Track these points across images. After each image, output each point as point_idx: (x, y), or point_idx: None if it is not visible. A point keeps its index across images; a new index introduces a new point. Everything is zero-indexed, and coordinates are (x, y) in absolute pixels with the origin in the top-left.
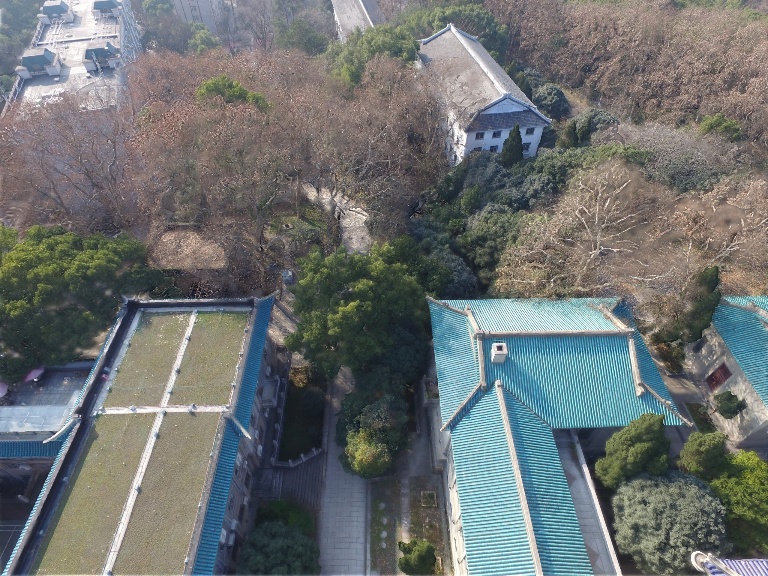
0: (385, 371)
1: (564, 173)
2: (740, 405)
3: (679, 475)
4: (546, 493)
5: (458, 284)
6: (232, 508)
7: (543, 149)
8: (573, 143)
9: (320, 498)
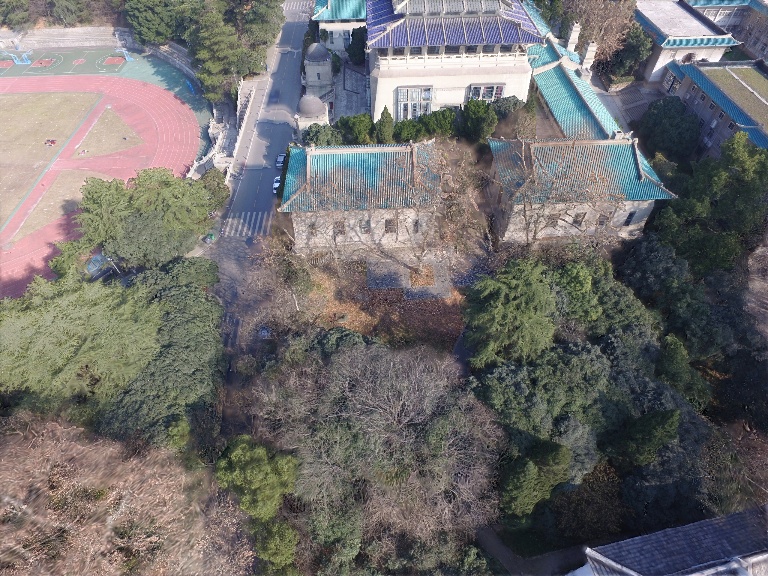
0: (673, 190)
1: None
2: None
3: (505, 117)
4: None
5: None
6: (716, 147)
7: (590, 459)
8: None
9: None
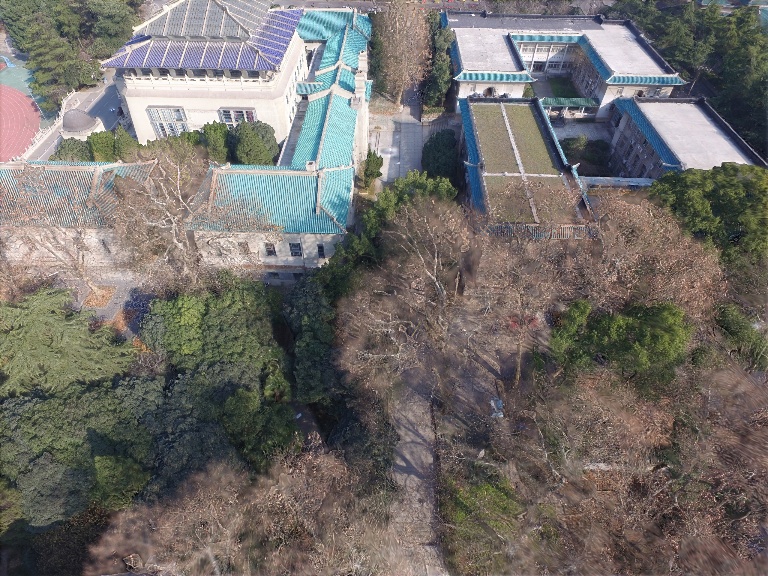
0: None
1: None
2: None
3: None
4: None
5: None
6: None
7: (48, 501)
8: None
9: None
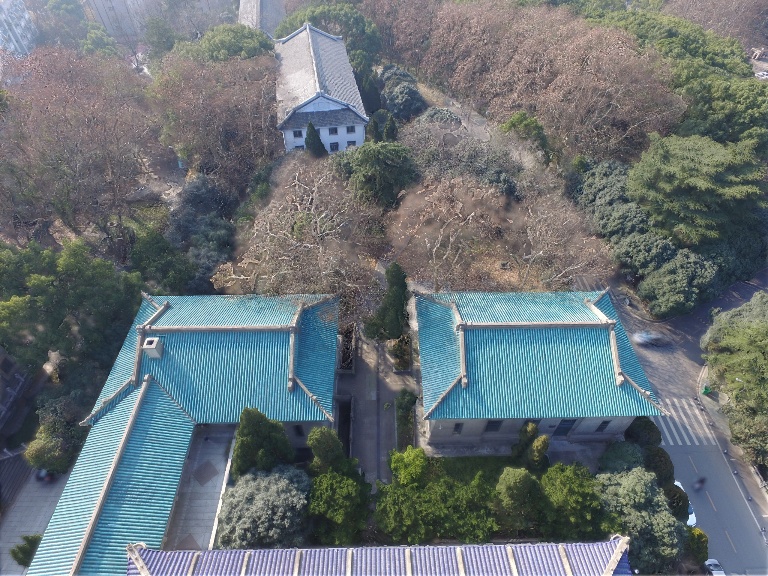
0: (92, 366)
1: (349, 171)
2: (411, 401)
3: (285, 470)
4: (143, 487)
5: (201, 281)
6: None
7: (350, 147)
8: (376, 141)
9: (18, 492)
